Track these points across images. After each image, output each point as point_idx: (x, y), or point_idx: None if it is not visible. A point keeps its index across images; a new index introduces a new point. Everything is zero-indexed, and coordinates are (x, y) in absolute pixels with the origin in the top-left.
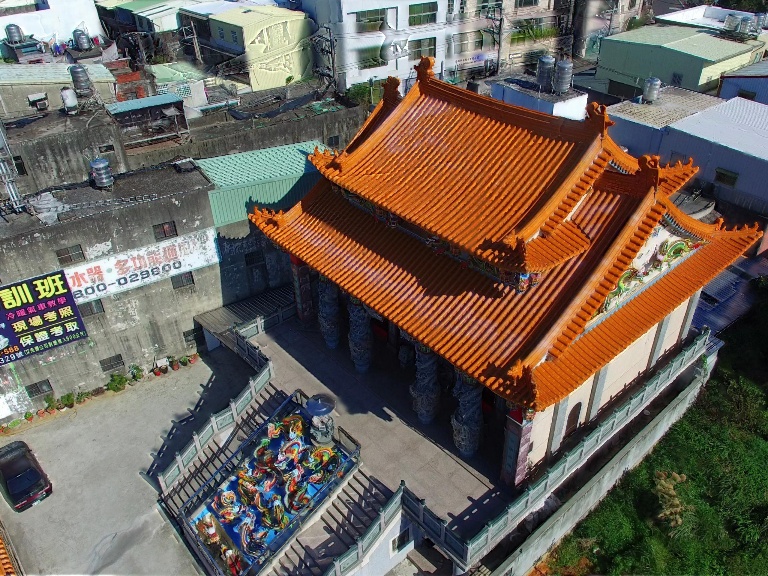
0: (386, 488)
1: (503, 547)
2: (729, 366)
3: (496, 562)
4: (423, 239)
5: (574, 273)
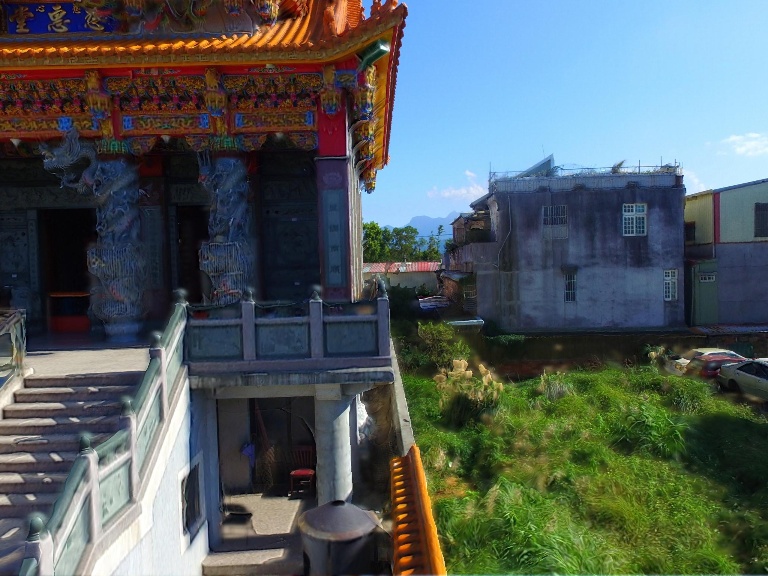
0: (124, 371)
1: (357, 483)
2: (400, 333)
3: (366, 500)
4: (53, 38)
5: (310, 23)
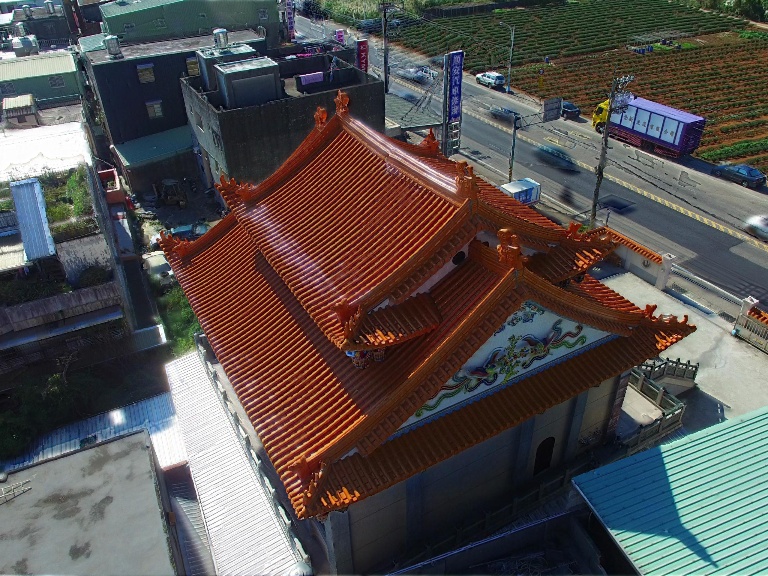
0: None
1: None
2: None
3: None
4: None
5: None
